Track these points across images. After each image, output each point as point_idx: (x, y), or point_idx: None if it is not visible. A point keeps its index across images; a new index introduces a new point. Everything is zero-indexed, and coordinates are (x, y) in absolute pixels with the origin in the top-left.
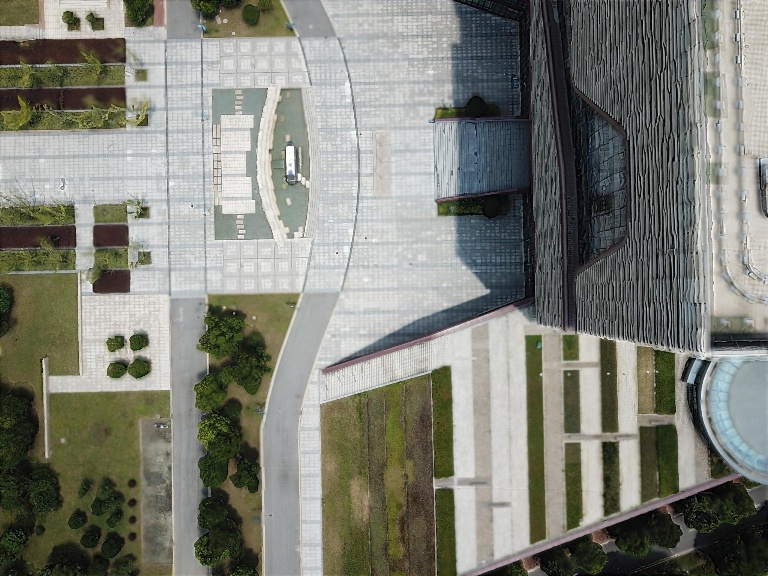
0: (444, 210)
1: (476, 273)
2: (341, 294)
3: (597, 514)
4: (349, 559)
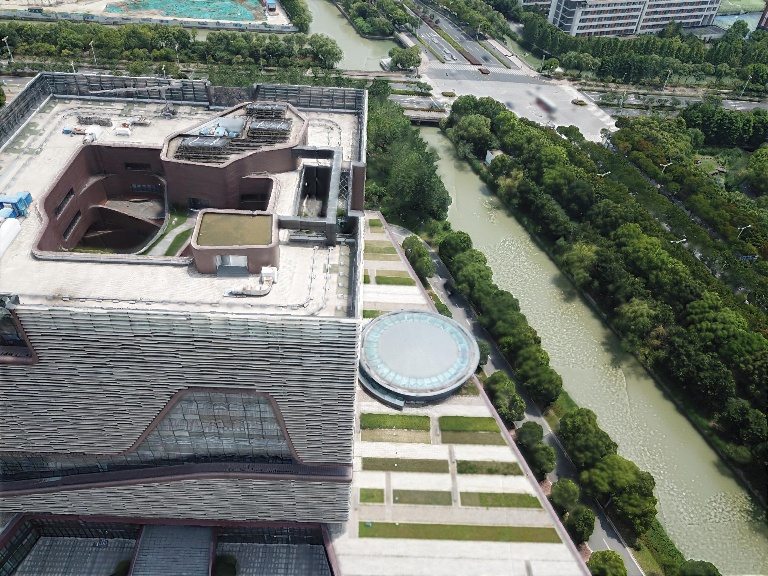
0: None
1: None
2: None
3: (523, 482)
4: None
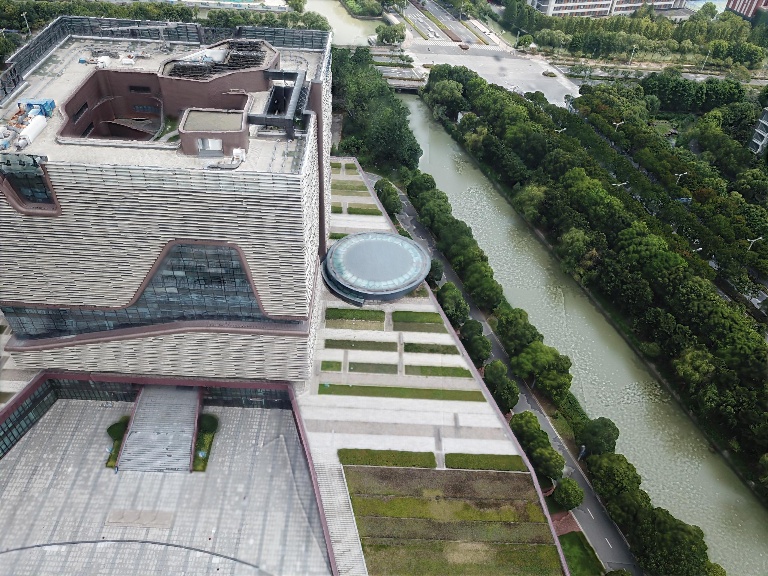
0: (201, 465)
1: (264, 444)
2: (261, 568)
3: (459, 359)
4: (529, 570)
